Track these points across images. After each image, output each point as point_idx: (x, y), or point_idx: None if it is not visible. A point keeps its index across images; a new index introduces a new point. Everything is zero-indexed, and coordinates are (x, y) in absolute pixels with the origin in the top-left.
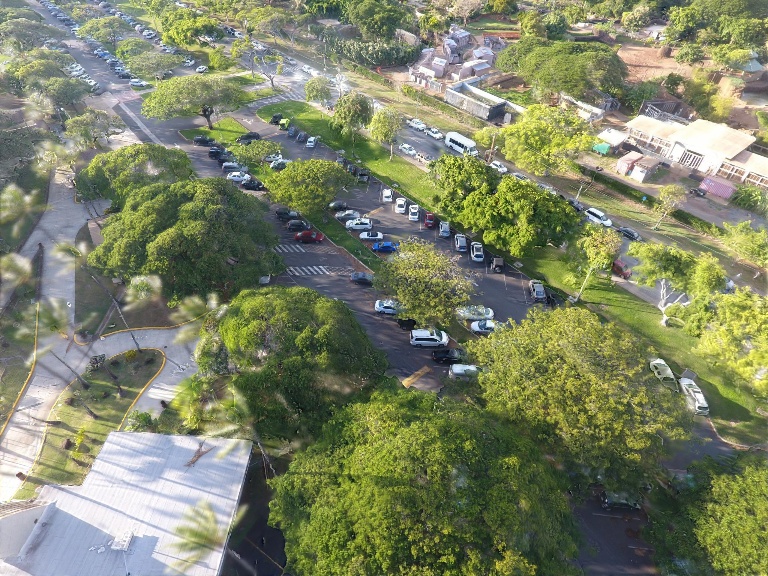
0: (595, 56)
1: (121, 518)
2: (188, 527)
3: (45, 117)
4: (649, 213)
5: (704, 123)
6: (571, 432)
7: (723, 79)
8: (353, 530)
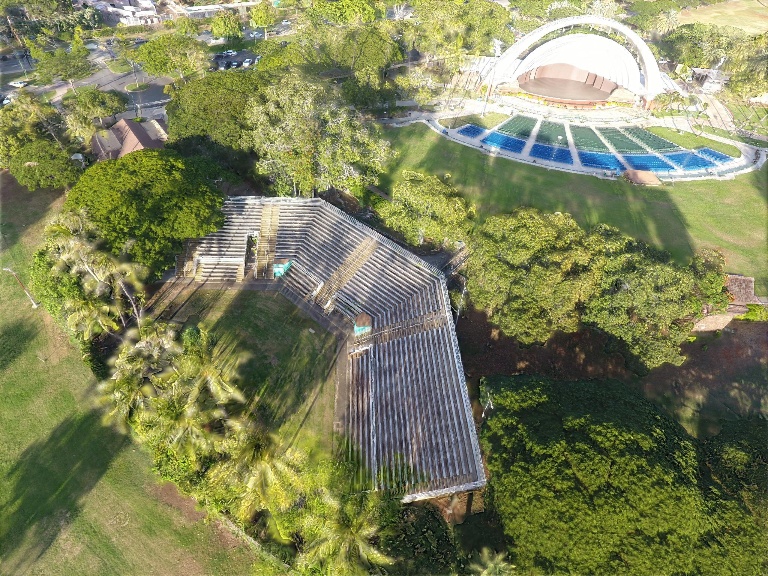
0: None
1: None
2: None
3: (90, 145)
4: None
5: None
6: None
7: None
8: (492, 26)
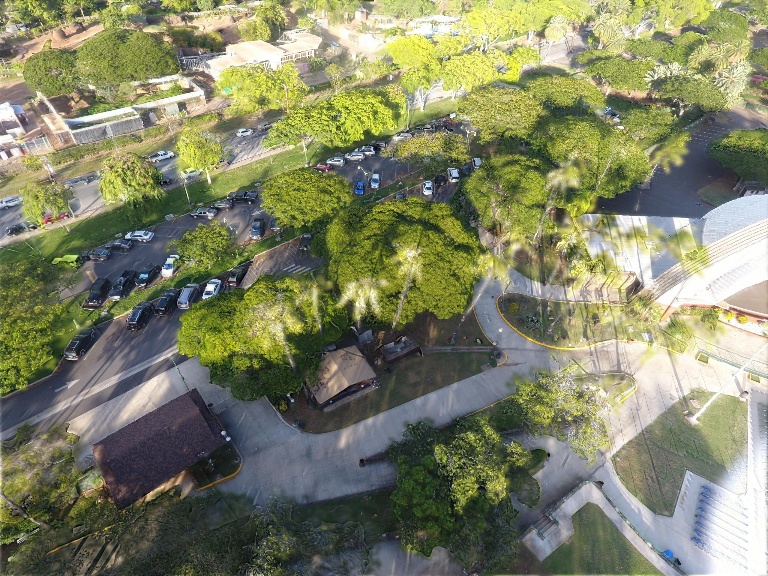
0: (146, 34)
1: (640, 250)
2: (628, 227)
3: None
4: (319, 95)
5: (234, 46)
6: (540, 112)
7: (145, 30)
8: (619, 152)
